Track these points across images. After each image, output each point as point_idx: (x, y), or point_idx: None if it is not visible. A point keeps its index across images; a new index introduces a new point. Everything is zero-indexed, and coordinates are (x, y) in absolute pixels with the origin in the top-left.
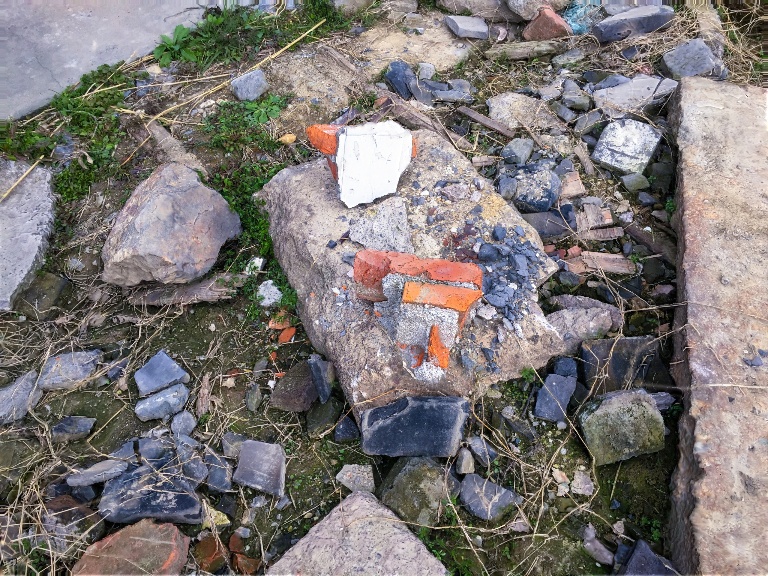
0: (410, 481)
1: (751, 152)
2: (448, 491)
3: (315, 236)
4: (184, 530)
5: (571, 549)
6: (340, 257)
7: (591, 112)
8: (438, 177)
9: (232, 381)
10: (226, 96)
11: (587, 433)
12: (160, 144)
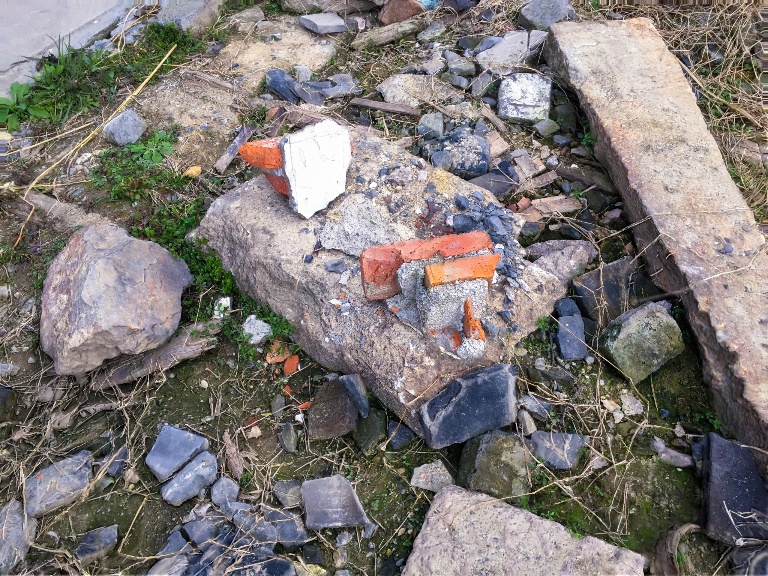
0: (491, 458)
1: (636, 76)
2: (529, 454)
3: (287, 255)
4: None
5: (651, 465)
6: (322, 268)
7: (482, 75)
8: (377, 167)
9: (258, 429)
10: (101, 145)
11: (617, 358)
12: (50, 213)
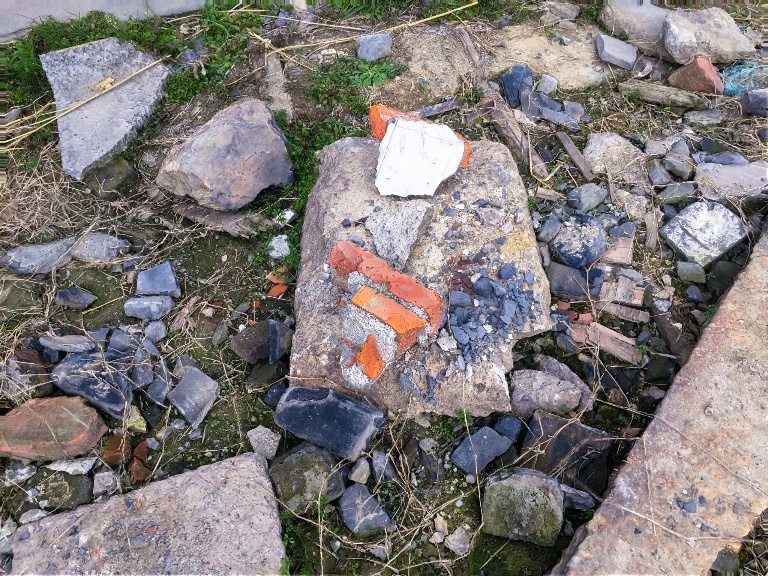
0: (298, 465)
1: None
2: (325, 489)
3: (336, 210)
4: (107, 420)
5: None
6: (347, 238)
7: (685, 183)
8: (483, 195)
9: (211, 311)
10: (349, 50)
11: (487, 497)
12: (268, 76)
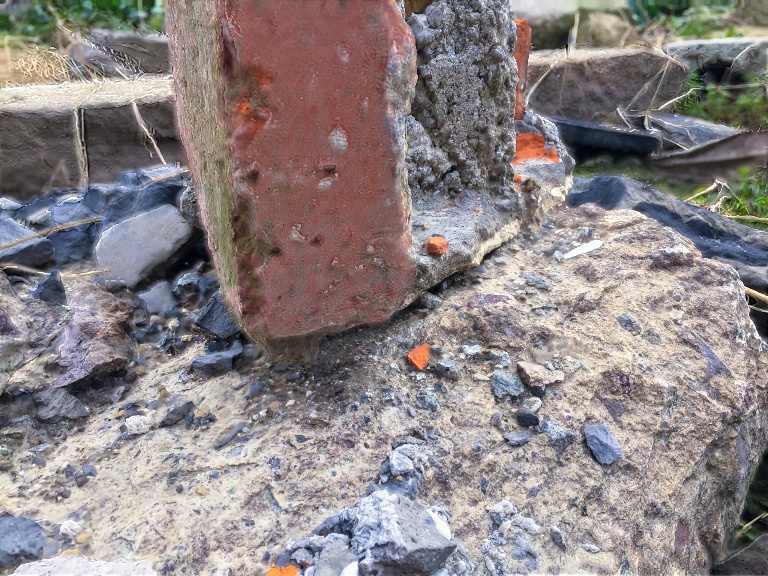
0: None
1: None
2: None
3: None
4: None
5: None
6: None
7: None
8: None
9: None
10: None
11: None
12: None
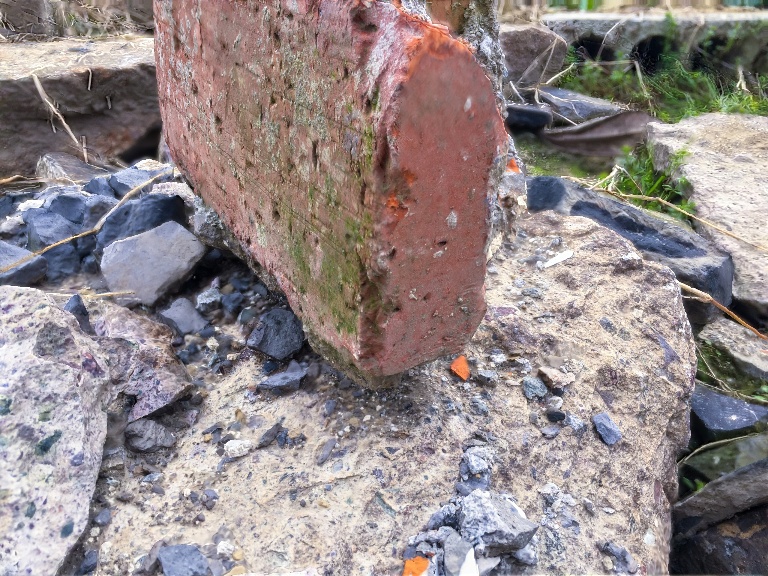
0: None
1: None
2: None
3: None
4: None
5: None
6: None
7: None
8: None
9: None
10: None
11: None
12: None
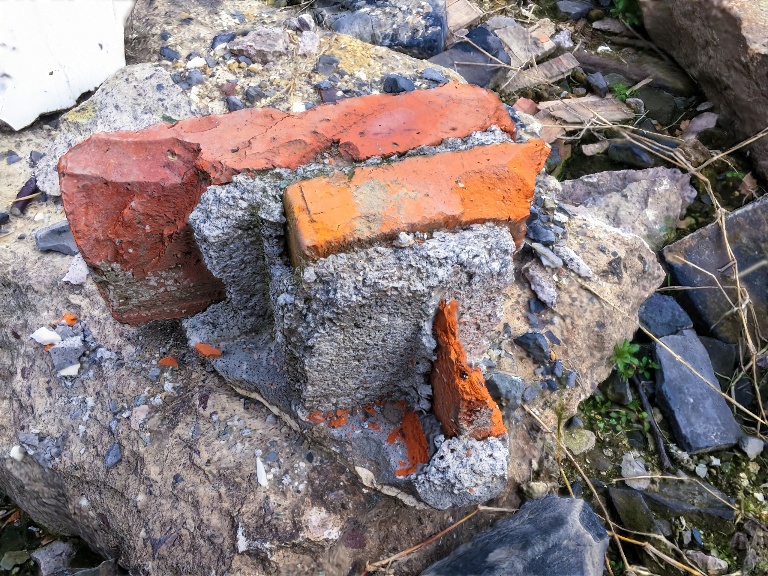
0: None
1: None
2: None
3: None
4: None
5: None
6: (29, 245)
7: None
8: (210, 33)
9: None
10: None
11: None
12: None
